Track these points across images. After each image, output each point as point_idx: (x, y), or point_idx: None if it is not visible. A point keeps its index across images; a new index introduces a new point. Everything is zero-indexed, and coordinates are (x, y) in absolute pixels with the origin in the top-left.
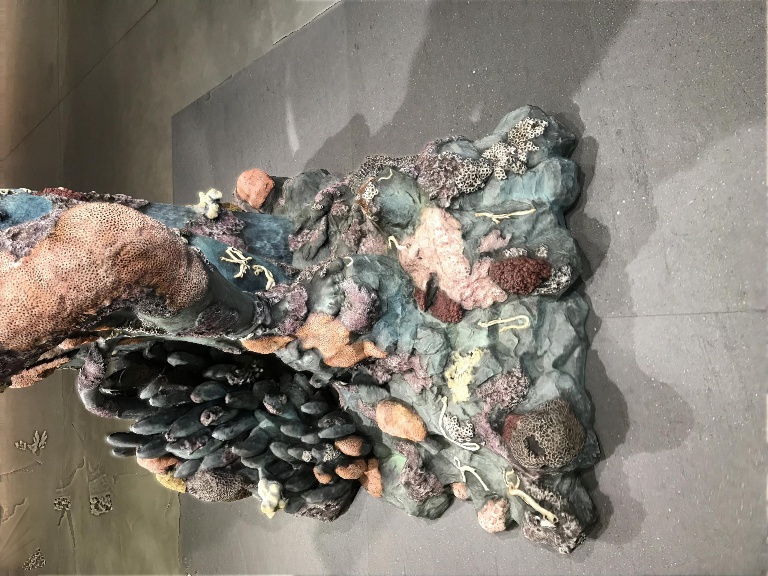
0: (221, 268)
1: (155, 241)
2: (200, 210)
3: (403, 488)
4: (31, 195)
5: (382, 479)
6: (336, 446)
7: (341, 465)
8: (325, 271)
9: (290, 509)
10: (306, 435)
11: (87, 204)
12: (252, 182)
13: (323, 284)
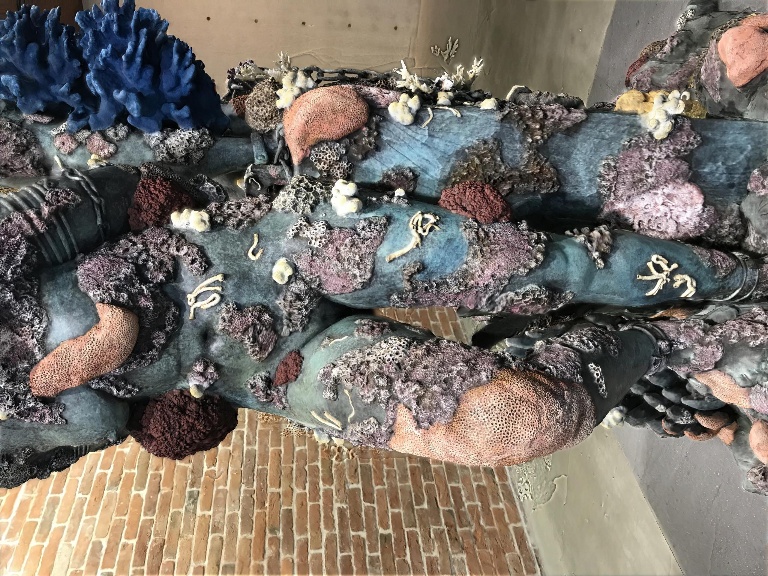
0: (633, 287)
1: (544, 446)
2: (647, 125)
3: (749, 469)
4: (450, 229)
5: (733, 442)
6: (695, 417)
7: (692, 431)
8: (758, 343)
9: (628, 420)
10: (669, 391)
11: (488, 392)
12: (742, 52)
13: (748, 354)
